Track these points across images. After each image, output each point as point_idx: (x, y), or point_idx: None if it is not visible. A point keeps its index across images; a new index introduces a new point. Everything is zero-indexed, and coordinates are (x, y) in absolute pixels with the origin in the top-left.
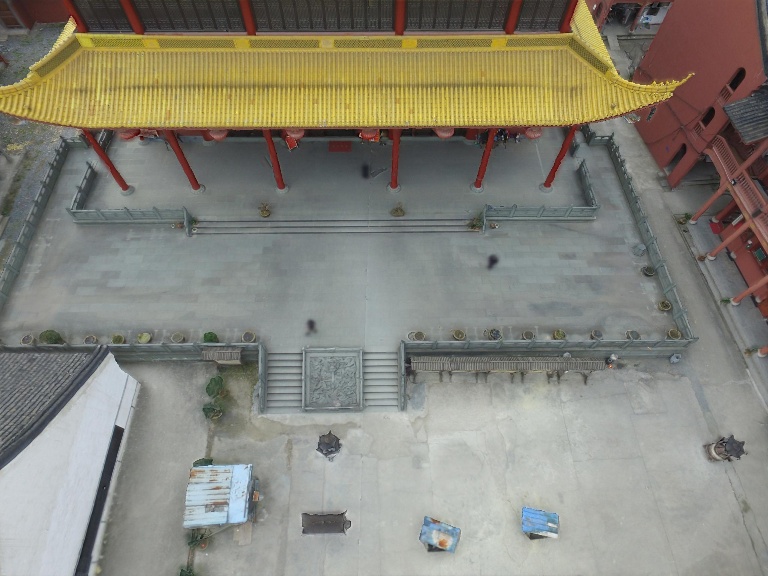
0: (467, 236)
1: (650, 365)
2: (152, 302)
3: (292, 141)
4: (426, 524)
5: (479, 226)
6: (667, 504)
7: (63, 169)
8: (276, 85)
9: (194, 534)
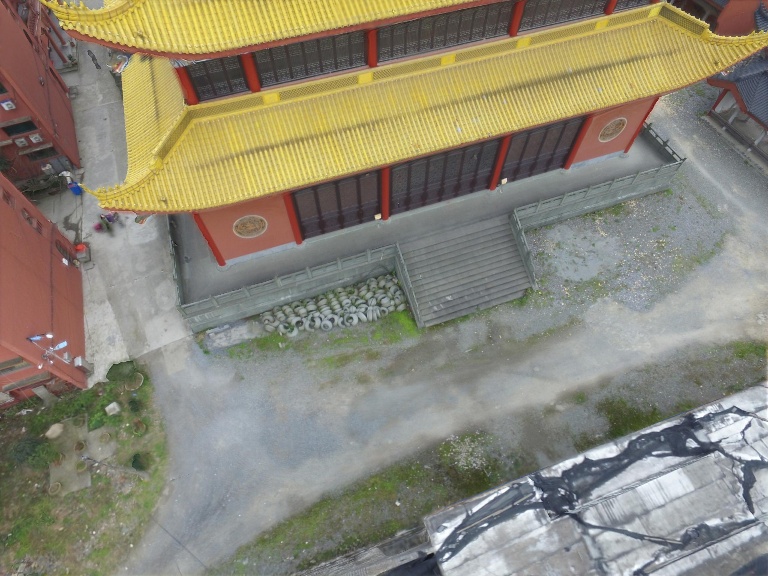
0: None
1: None
2: None
3: None
4: None
5: None
6: None
7: None
8: None
9: None
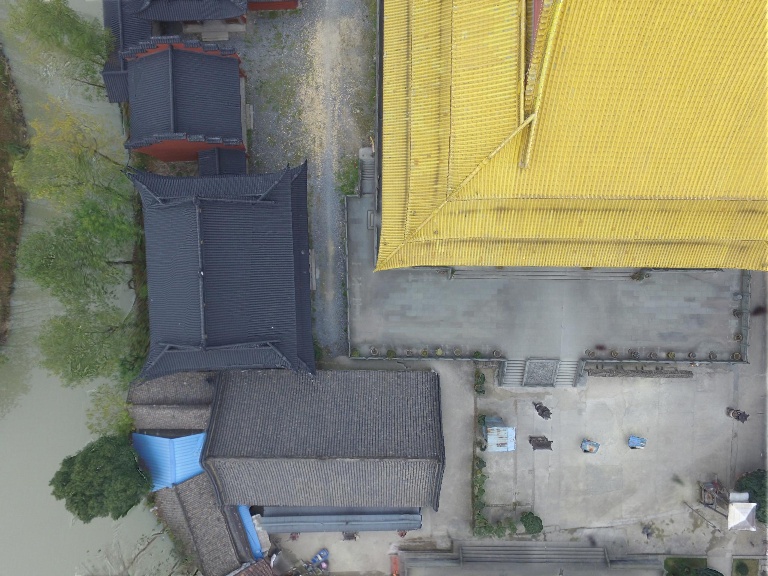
0: (629, 283)
1: (715, 365)
2: (436, 327)
3: None
4: (584, 442)
5: (639, 280)
6: (698, 434)
7: (349, 218)
8: (551, 241)
9: (475, 441)
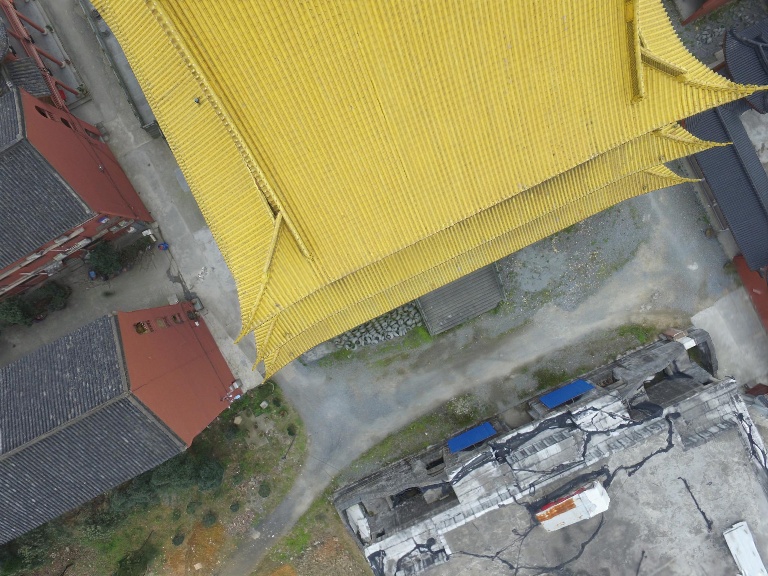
0: None
1: None
2: None
3: None
4: None
5: None
6: None
7: None
8: None
9: None
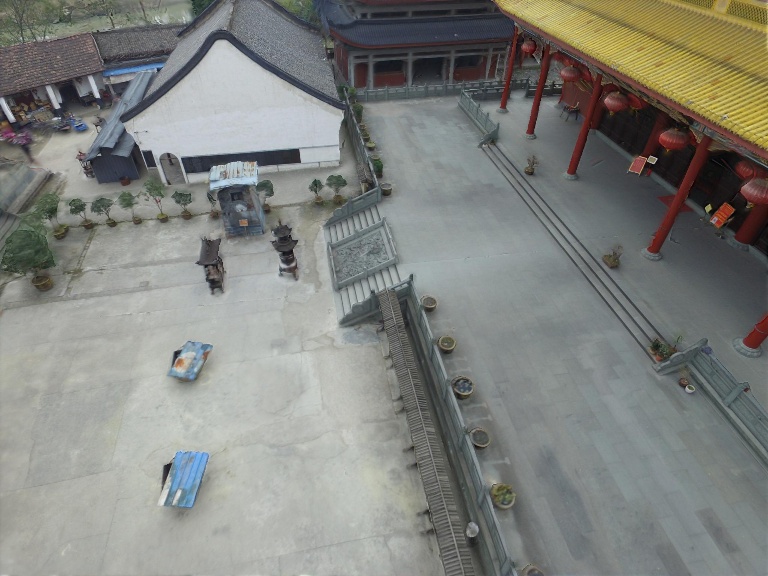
0: (635, 350)
1: None
2: (405, 145)
3: (640, 165)
4: (204, 346)
5: (662, 353)
6: None
7: None
8: (632, 27)
9: None
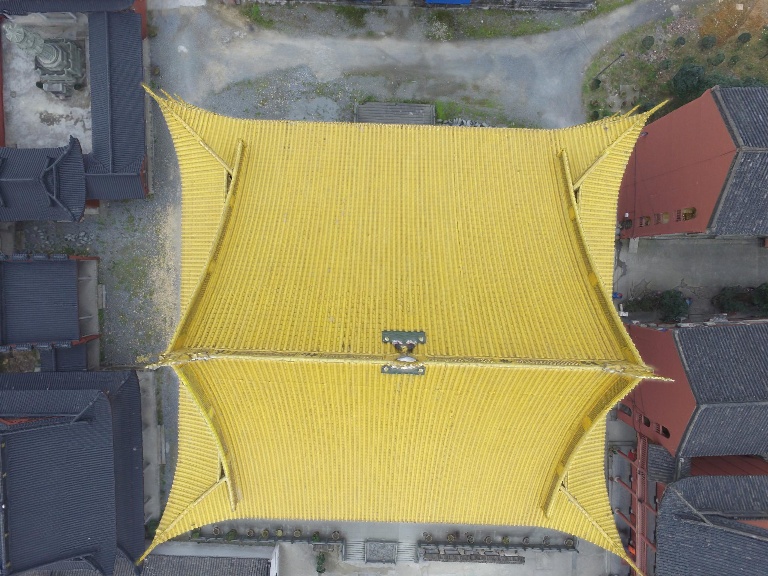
0: None
1: None
2: None
3: None
4: None
5: None
6: None
7: None
8: None
9: None
